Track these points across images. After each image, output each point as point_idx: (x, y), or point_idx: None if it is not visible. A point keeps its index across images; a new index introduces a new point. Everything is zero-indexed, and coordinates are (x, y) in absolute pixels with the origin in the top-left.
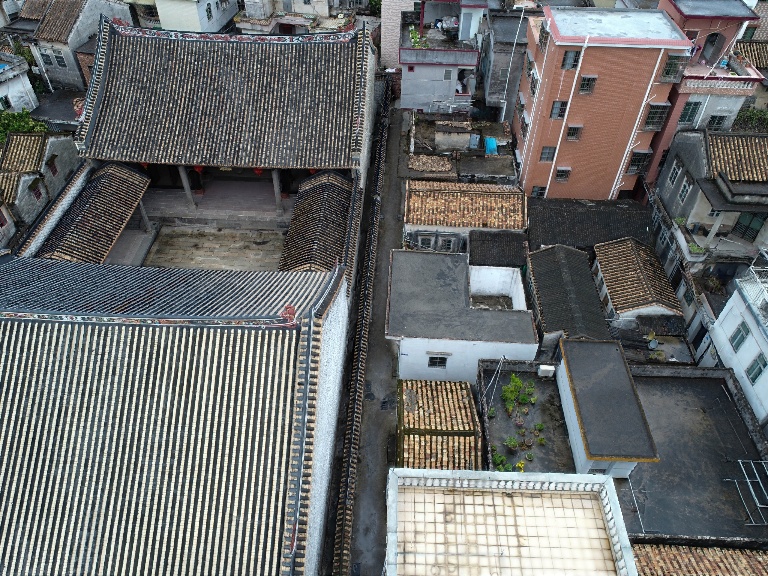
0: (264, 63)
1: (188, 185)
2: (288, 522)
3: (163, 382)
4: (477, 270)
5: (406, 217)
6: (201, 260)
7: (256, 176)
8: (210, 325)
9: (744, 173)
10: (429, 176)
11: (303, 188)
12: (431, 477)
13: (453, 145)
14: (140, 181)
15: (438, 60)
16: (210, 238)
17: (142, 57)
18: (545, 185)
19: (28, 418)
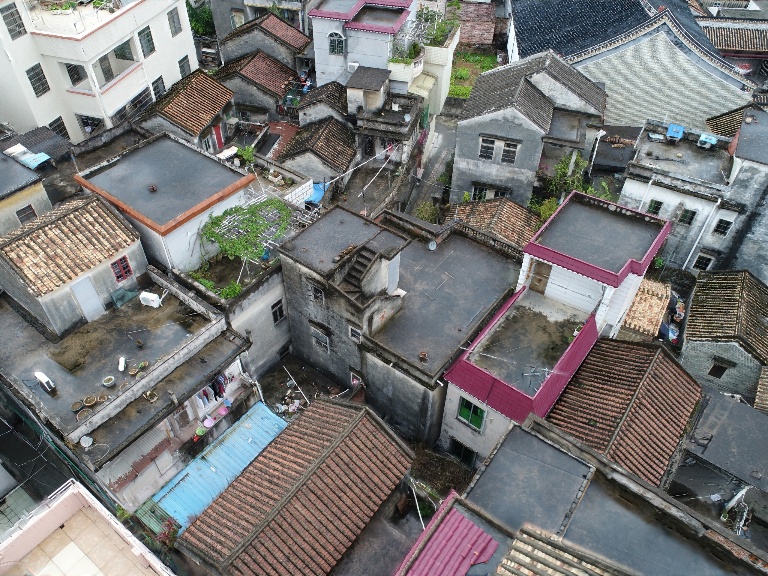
0: None
1: None
2: None
3: None
4: None
5: (706, 15)
6: None
7: None
8: None
9: None
10: None
11: None
12: None
13: None
14: None
15: None
16: None
17: None
18: None
19: None
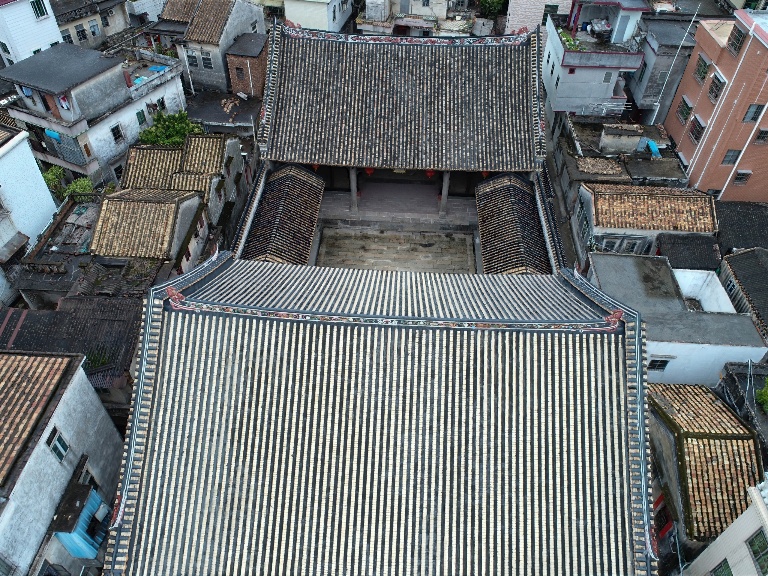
0: (435, 65)
1: (356, 187)
2: (636, 526)
3: (484, 385)
4: None
5: (596, 220)
6: (373, 262)
7: (407, 178)
8: (527, 329)
9: None
10: (603, 179)
11: (482, 190)
12: None
13: (621, 148)
14: (317, 183)
15: (601, 63)
16: (375, 240)
17: (312, 59)
18: (721, 188)
19: (351, 421)
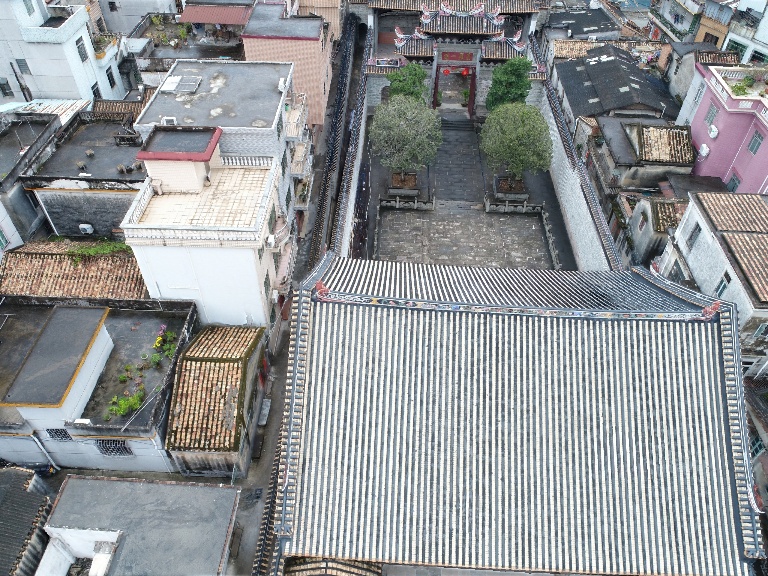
0: None
1: None
2: None
3: None
4: None
5: None
6: None
7: None
8: None
9: None
10: None
11: None
12: None
13: None
14: None
15: None
16: None
17: None
18: None
19: None
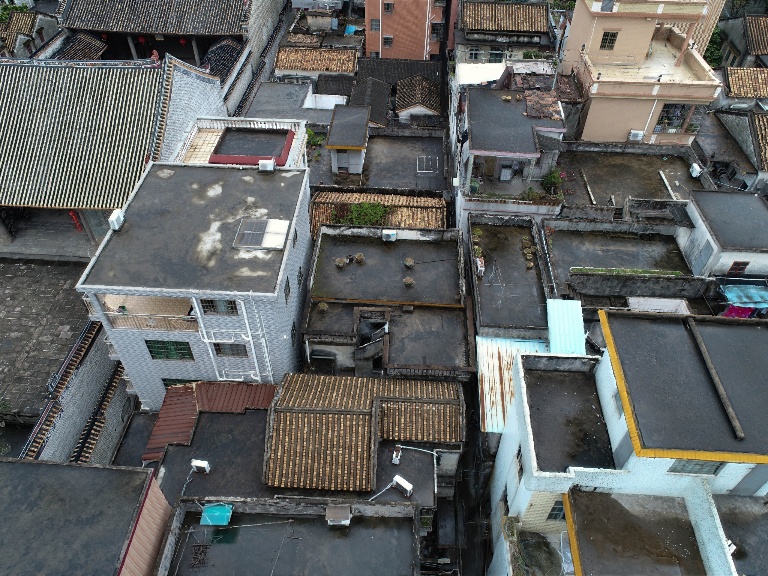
0: None
1: (135, 53)
2: None
3: (87, 96)
4: (320, 98)
5: (275, 64)
6: None
7: (189, 56)
8: (114, 66)
9: (484, 25)
10: (300, 45)
11: (210, 50)
12: (214, 118)
13: (320, 26)
14: (100, 45)
15: None
16: None
17: None
18: (378, 51)
19: (14, 113)
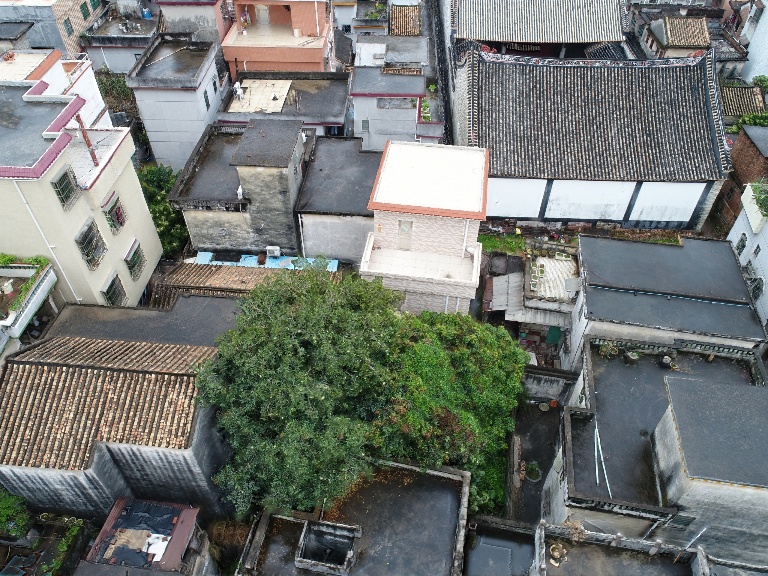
0: None
1: None
2: None
3: None
4: None
5: None
6: None
7: None
8: None
9: None
10: None
11: None
12: None
13: None
14: None
15: None
16: None
17: None
18: None
19: None
